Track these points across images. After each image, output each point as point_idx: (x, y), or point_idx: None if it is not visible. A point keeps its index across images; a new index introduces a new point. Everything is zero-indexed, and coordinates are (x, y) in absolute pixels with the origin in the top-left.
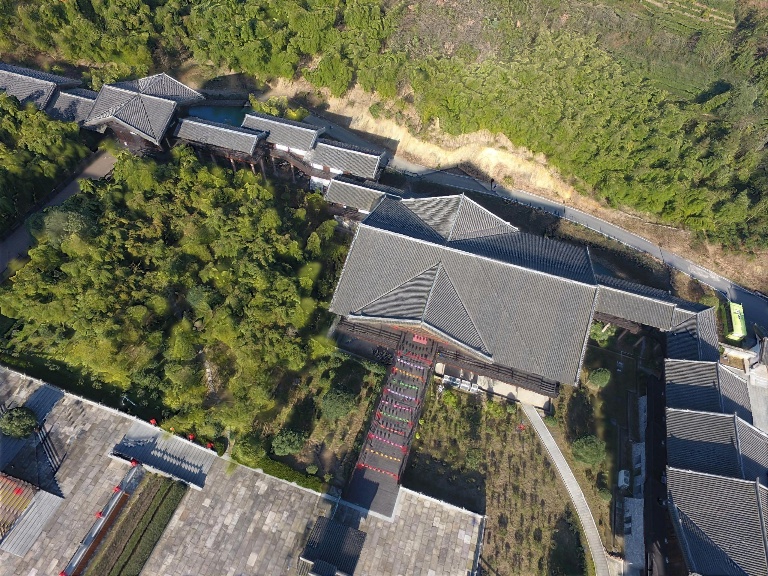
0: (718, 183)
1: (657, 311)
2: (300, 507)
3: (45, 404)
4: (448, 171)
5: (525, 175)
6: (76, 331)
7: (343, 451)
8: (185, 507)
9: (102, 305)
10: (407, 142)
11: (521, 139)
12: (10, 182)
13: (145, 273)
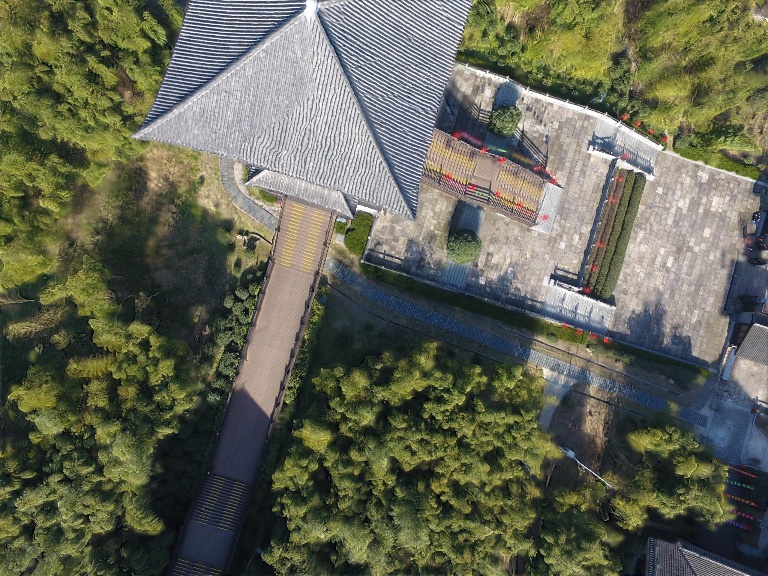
0: None
1: None
2: (739, 192)
3: (510, 103)
4: None
5: None
6: (498, 19)
7: (763, 144)
8: (643, 194)
9: None
10: None
11: None
12: None
13: None
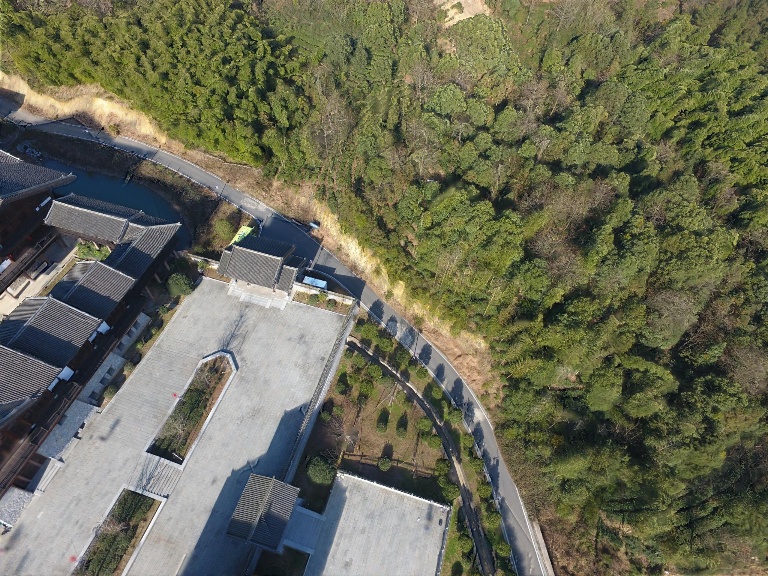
0: (281, 124)
1: (111, 226)
2: None
3: None
4: (64, 121)
5: (132, 123)
6: None
7: None
8: None
9: None
10: (29, 95)
11: (108, 87)
12: None
13: None
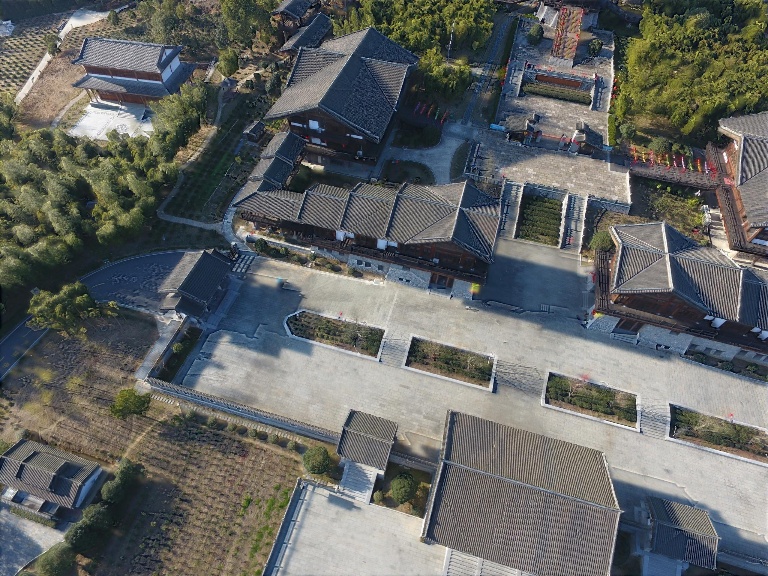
0: None
1: None
2: None
3: (604, 54)
4: None
5: None
6: None
7: None
8: (581, 106)
9: (665, 40)
10: None
11: None
12: (708, 2)
13: (691, 52)
